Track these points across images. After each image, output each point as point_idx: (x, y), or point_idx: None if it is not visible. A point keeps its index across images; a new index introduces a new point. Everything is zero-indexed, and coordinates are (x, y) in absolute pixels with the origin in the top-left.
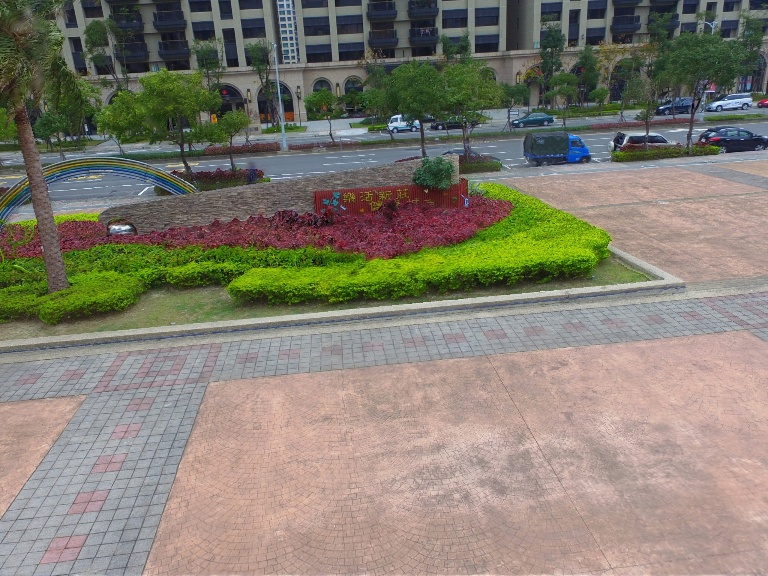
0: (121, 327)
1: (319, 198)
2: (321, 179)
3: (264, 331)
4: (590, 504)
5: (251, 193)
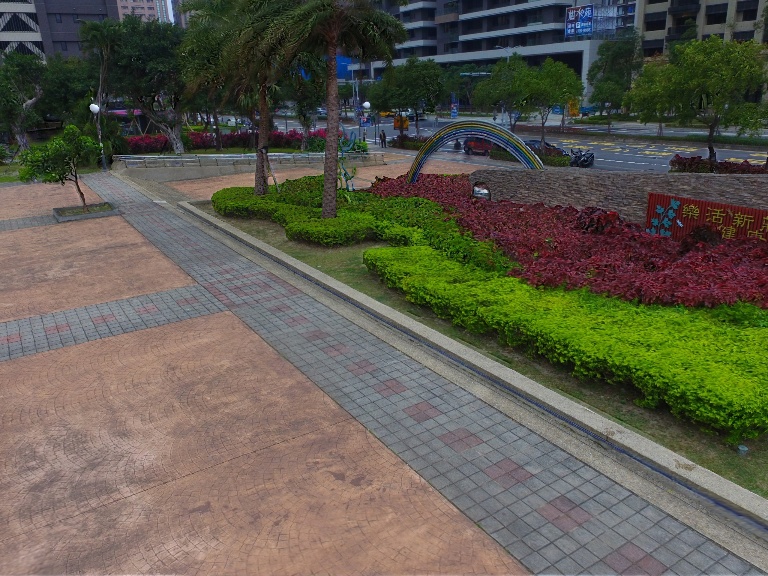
0: (303, 256)
1: (653, 203)
2: (664, 179)
3: (337, 299)
4: None
5: (586, 180)
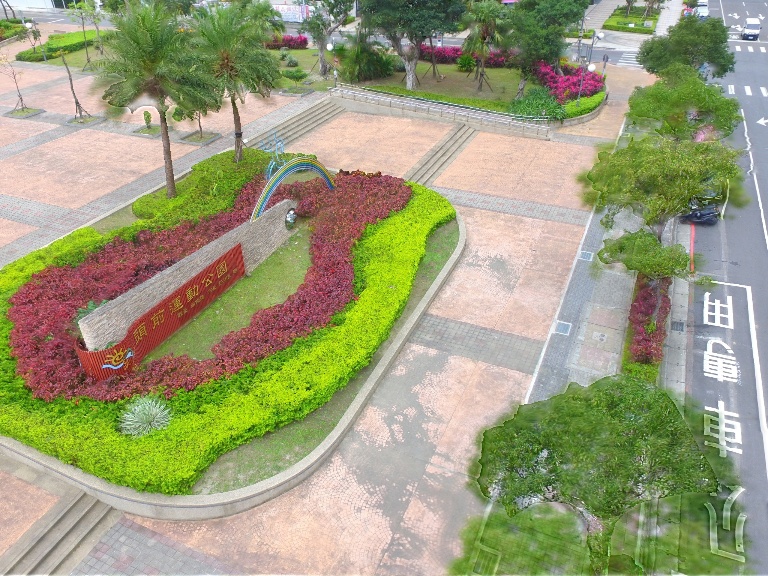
0: None
1: None
2: None
3: None
4: None
5: None
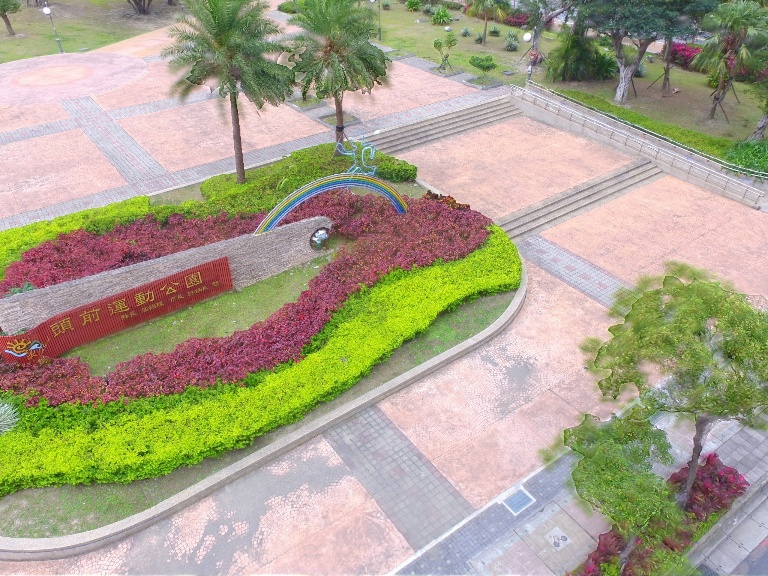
0: None
1: None
2: None
3: None
4: (4, 183)
5: None
